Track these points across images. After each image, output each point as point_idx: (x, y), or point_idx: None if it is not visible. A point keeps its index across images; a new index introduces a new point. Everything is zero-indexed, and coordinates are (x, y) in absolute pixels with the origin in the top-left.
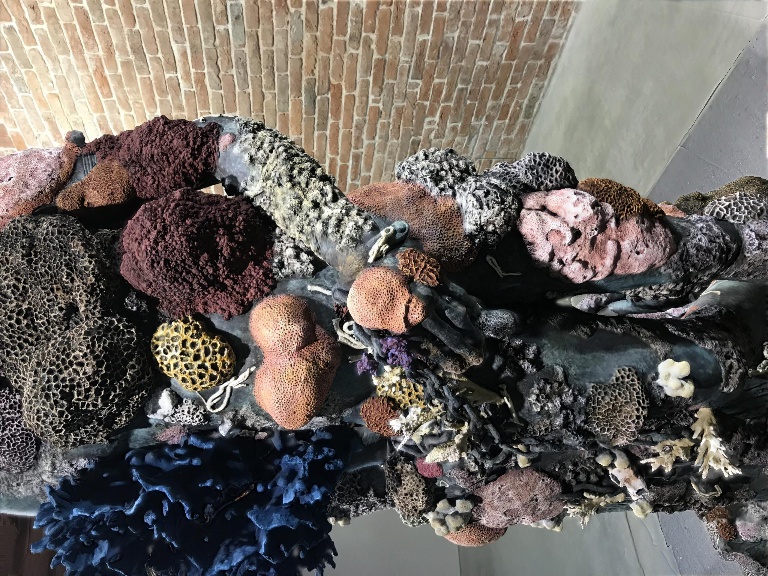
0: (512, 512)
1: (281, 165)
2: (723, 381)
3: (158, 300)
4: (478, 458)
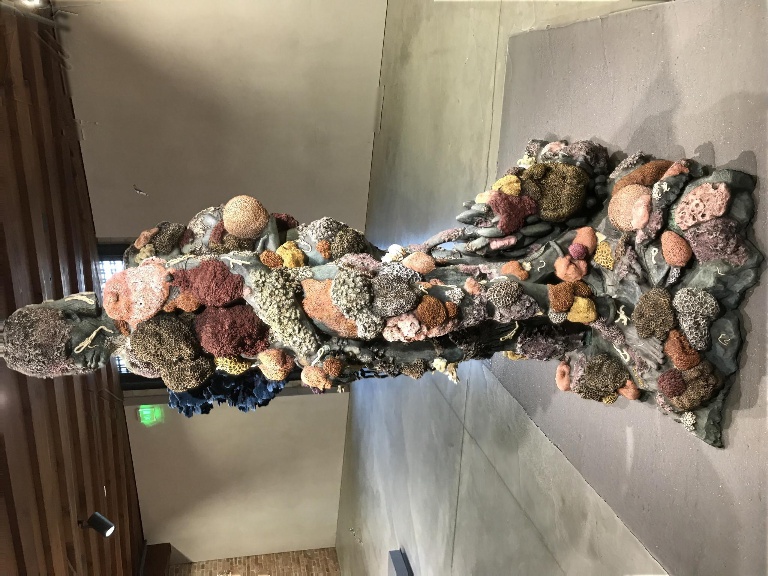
0: None
1: (275, 312)
2: None
3: None
4: None
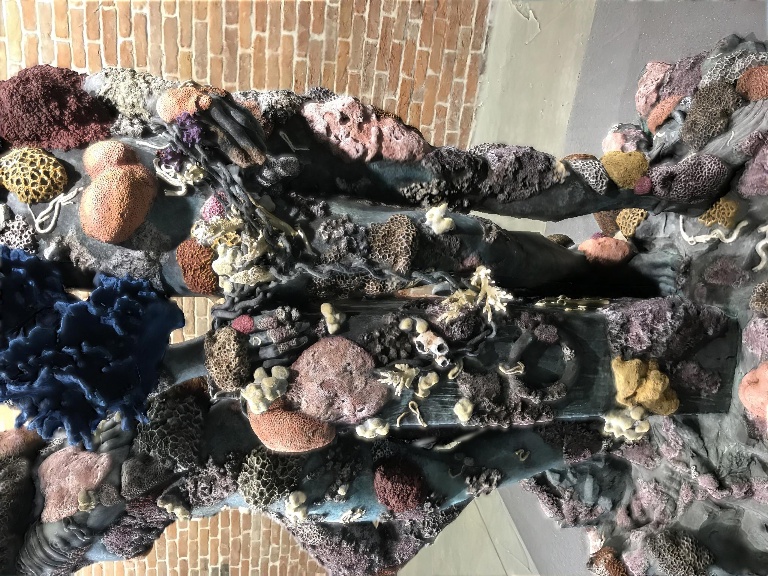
0: (328, 386)
1: None
2: (484, 233)
3: (12, 144)
4: (275, 273)
